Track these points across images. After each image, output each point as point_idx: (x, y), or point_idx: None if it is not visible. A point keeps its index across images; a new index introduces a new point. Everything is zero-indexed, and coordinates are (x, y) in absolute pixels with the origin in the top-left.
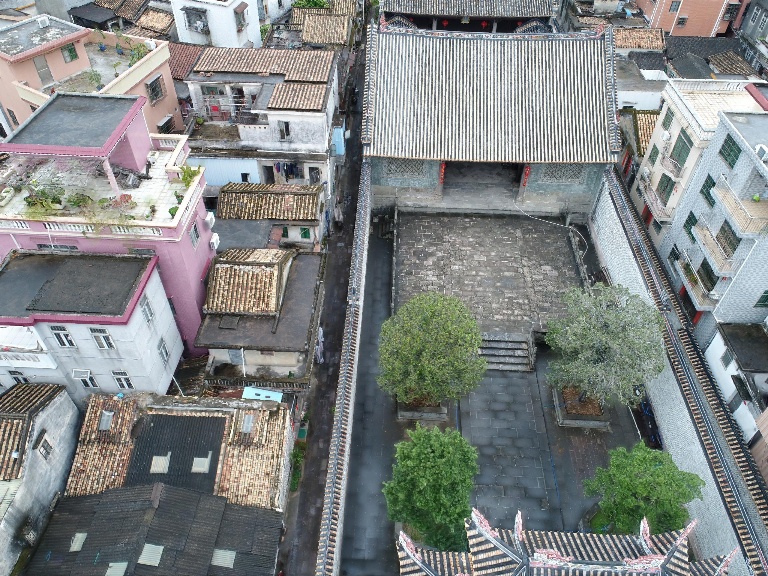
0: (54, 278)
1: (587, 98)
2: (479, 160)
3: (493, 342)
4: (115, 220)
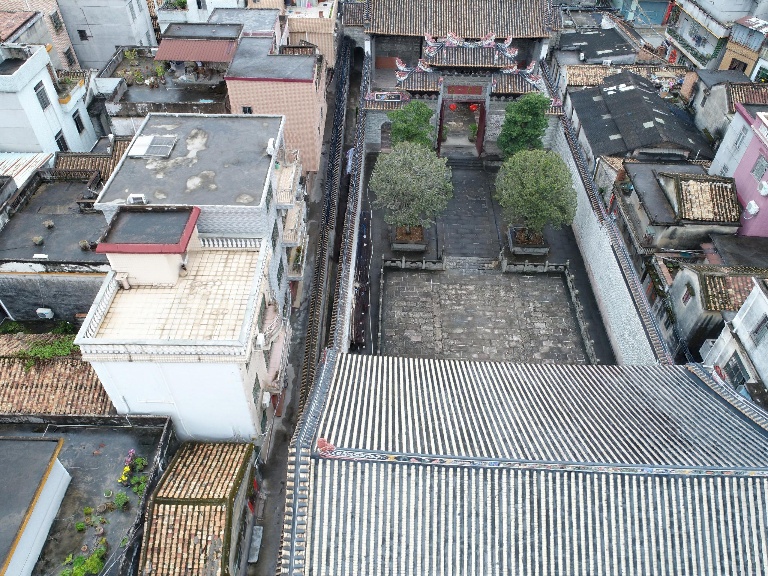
0: None
1: (360, 400)
2: None
3: None
4: None
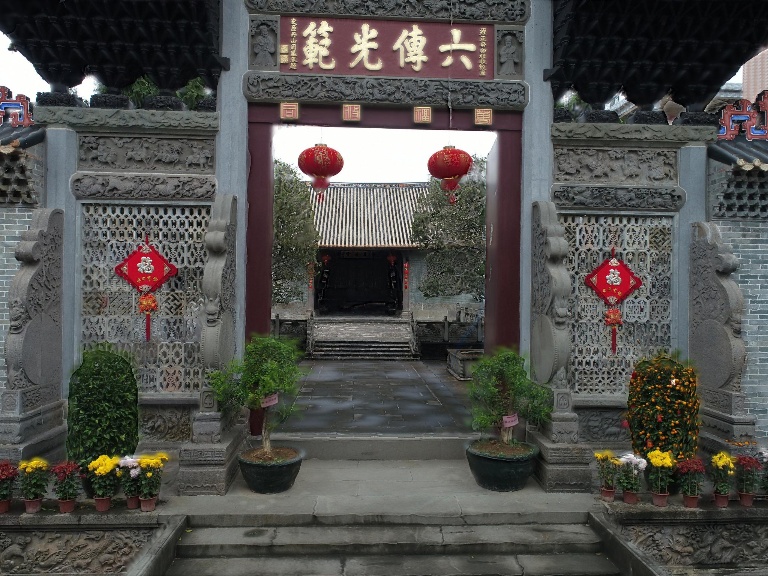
0: None
1: None
2: (348, 245)
3: (358, 343)
4: None
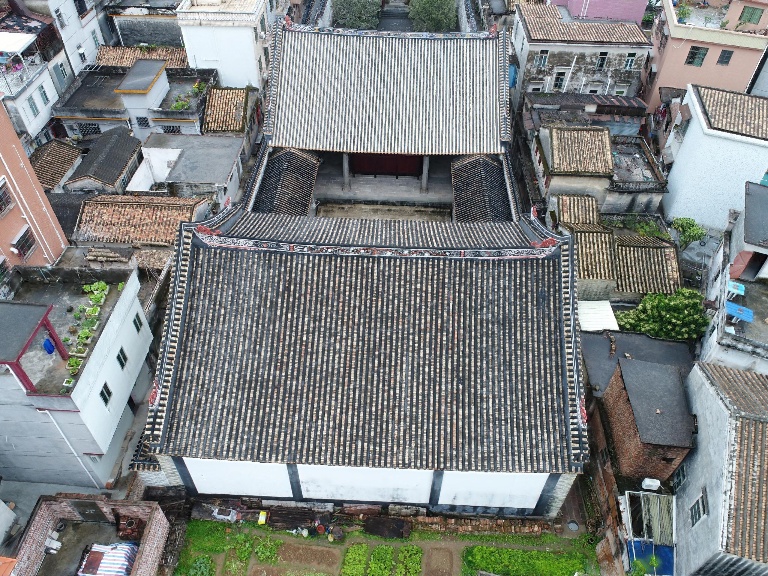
0: None
1: None
2: None
3: None
4: None
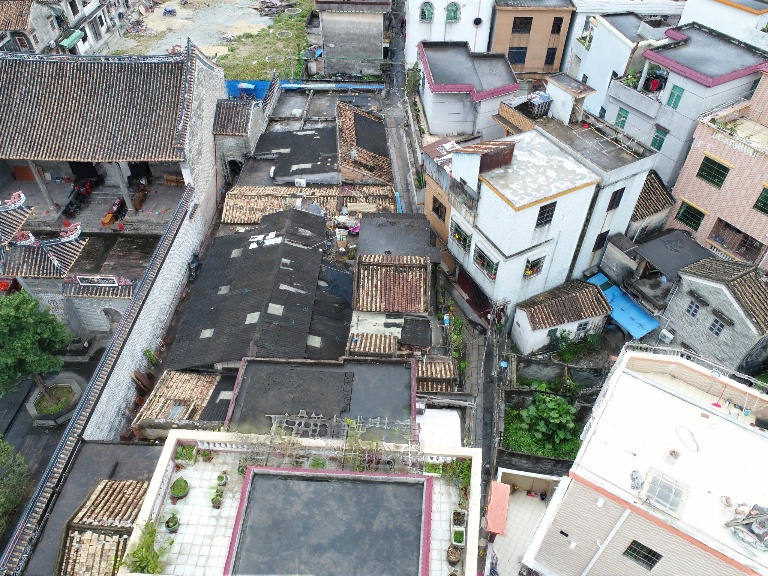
0: (340, 414)
1: None
2: None
3: None
4: (255, 439)
